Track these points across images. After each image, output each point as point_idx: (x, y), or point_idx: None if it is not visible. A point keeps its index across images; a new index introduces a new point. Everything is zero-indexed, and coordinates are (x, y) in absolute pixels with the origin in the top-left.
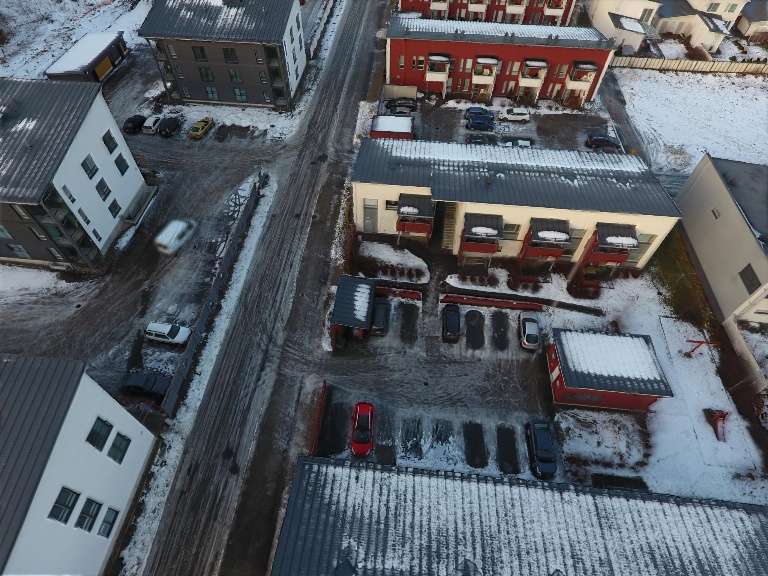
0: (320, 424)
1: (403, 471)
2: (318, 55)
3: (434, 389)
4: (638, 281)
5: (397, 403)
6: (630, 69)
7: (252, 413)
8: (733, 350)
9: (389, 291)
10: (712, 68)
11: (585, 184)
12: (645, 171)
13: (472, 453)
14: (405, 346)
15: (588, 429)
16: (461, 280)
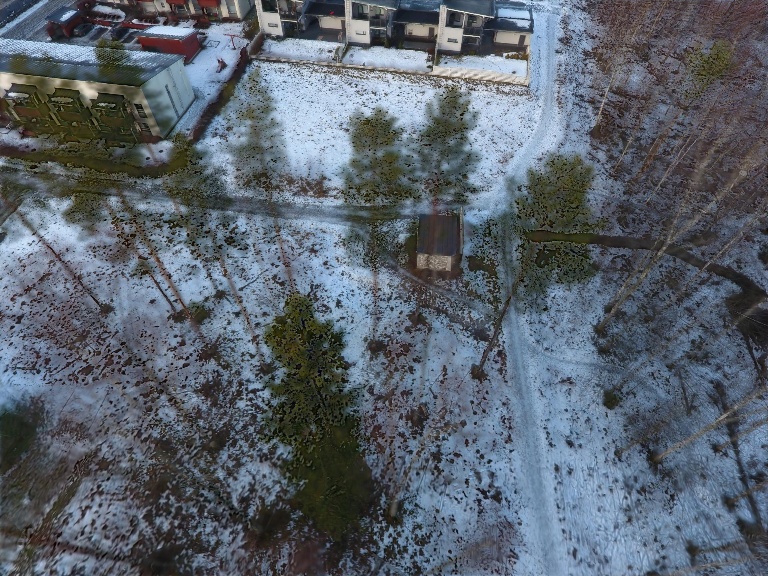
0: None
1: None
2: None
3: None
4: (236, 24)
5: None
6: None
7: None
8: None
9: (94, 20)
10: None
11: None
12: None
13: None
14: (90, 41)
15: None
16: (139, 20)
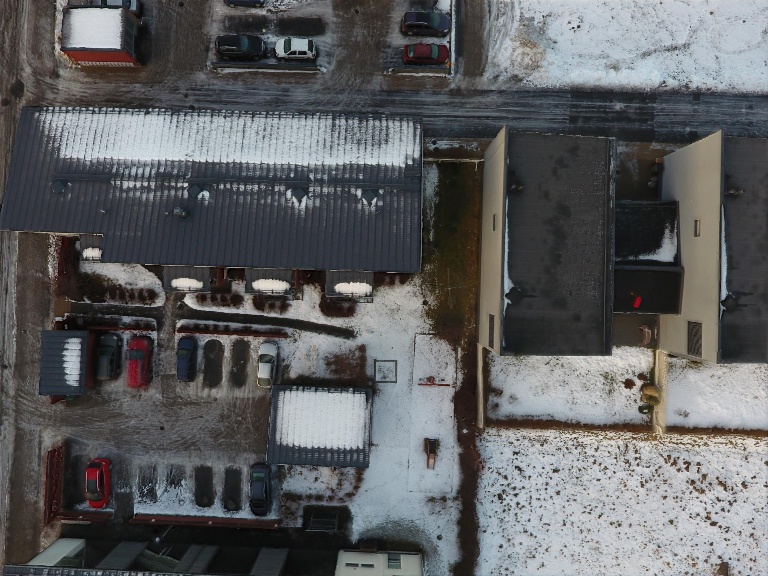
0: (62, 478)
1: (93, 575)
2: None
3: (169, 434)
4: (404, 288)
5: (134, 451)
6: None
7: (0, 469)
8: (474, 379)
9: (114, 328)
10: None
11: (315, 206)
12: (411, 164)
13: (201, 494)
14: (140, 389)
15: (309, 466)
16: (200, 301)
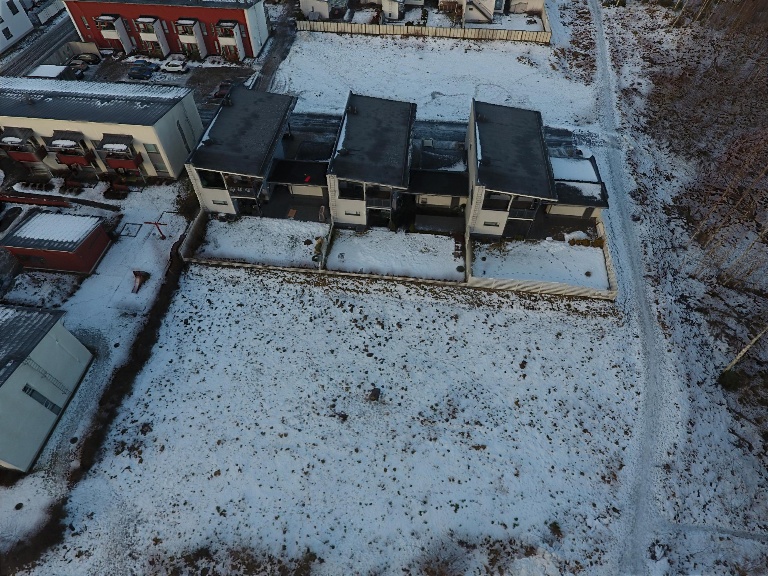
0: None
1: None
2: (52, 22)
3: None
4: (167, 187)
5: None
6: (305, 31)
7: None
8: None
9: None
10: (380, 31)
11: (109, 105)
12: (176, 98)
13: None
14: None
15: (35, 284)
16: (24, 186)
